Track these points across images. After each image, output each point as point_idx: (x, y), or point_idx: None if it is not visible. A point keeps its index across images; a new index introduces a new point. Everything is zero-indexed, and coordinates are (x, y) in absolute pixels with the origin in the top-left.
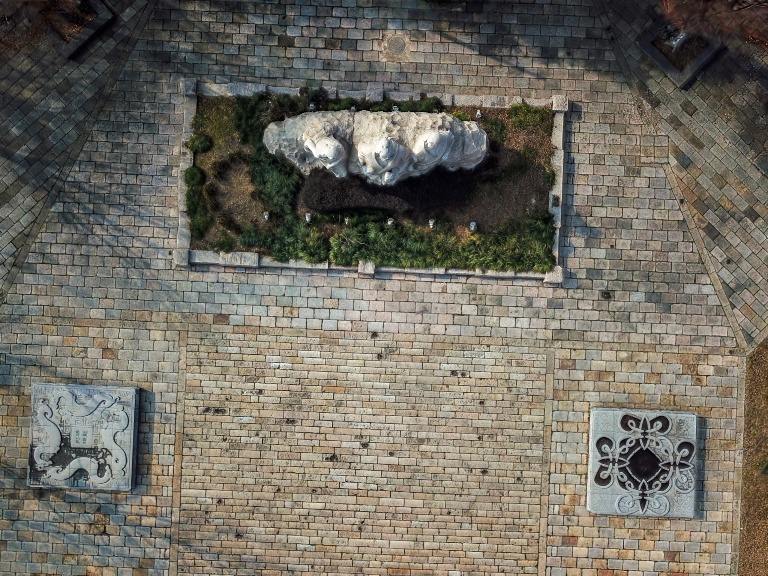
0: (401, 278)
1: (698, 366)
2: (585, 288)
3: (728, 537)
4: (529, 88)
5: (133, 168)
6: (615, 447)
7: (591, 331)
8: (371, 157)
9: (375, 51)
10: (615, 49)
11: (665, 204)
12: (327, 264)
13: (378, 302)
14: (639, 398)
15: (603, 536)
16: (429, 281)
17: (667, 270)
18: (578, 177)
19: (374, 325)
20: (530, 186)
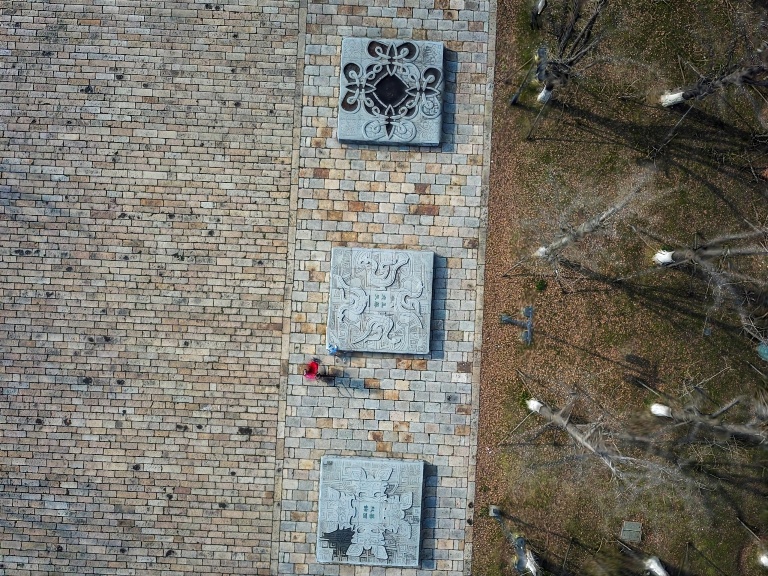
0: None
1: (450, 1)
2: None
3: (478, 170)
4: None
5: None
6: (362, 73)
7: None
8: None
9: None
10: None
11: None
12: None
13: None
14: (391, 32)
15: (355, 168)
16: None
17: None
18: None
19: None
20: None
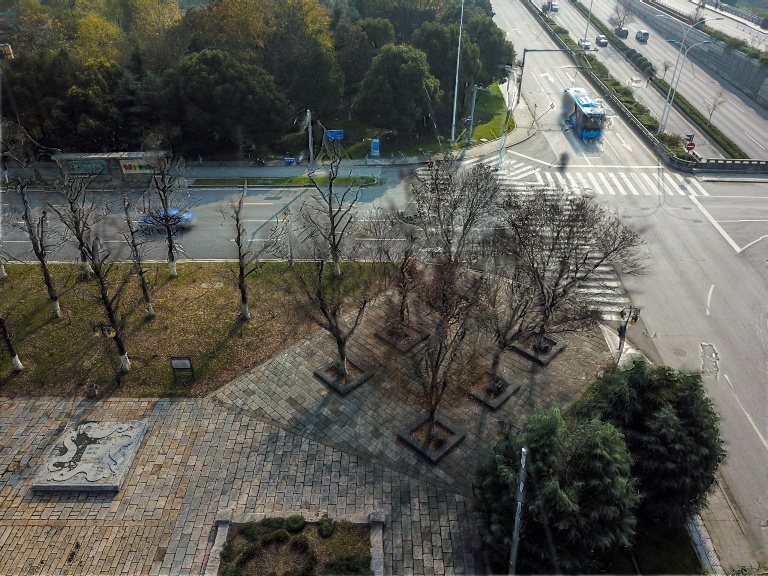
0: None
1: None
2: None
3: None
4: None
5: (310, 480)
6: None
7: None
8: None
9: None
10: None
11: None
12: None
13: None
14: None
15: None
16: None
17: None
18: None
19: None
20: None
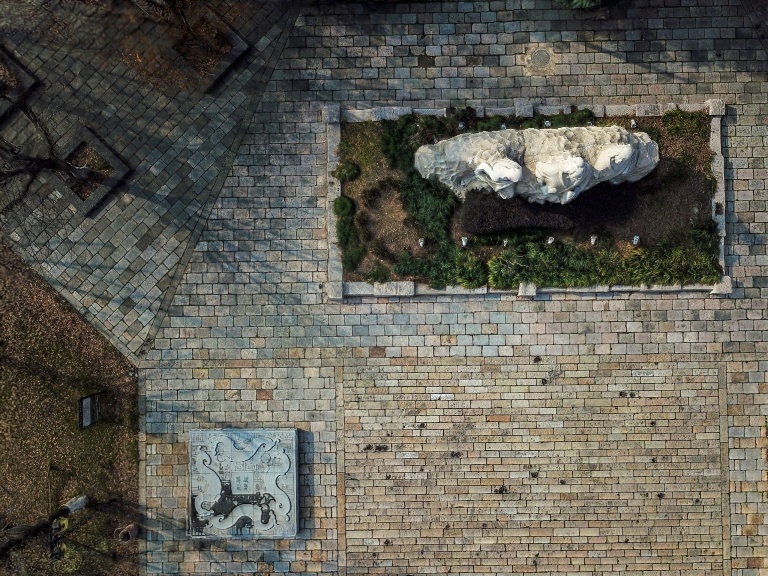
0: (561, 298)
1: None
2: (753, 297)
3: None
4: (680, 94)
5: (277, 201)
6: None
7: (762, 341)
8: (557, 177)
9: (518, 66)
10: (767, 48)
11: None
12: (486, 289)
13: (539, 324)
14: None
15: None
16: (590, 300)
17: None
18: (738, 182)
19: (536, 349)
20: (692, 195)
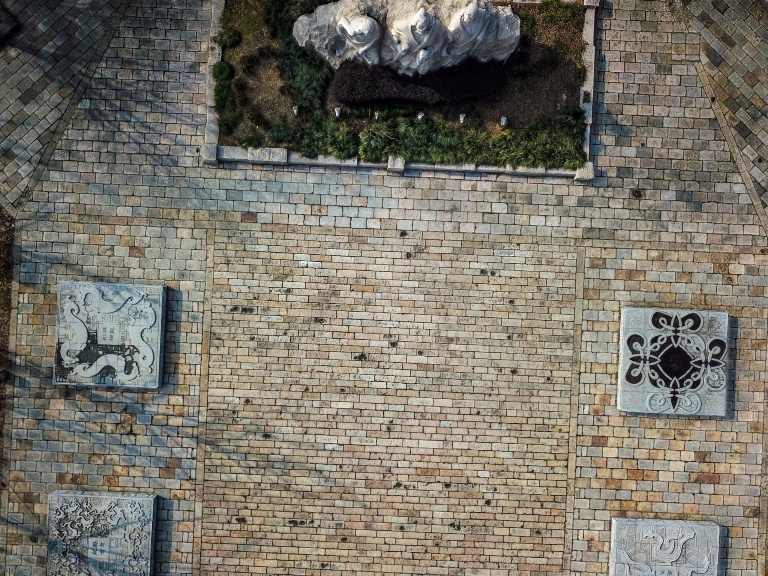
0: (430, 176)
1: (729, 265)
2: (616, 186)
3: (759, 437)
4: None
5: (160, 64)
6: (646, 344)
7: (622, 230)
8: (407, 31)
9: None
10: None
11: (696, 102)
12: (356, 160)
13: (407, 200)
14: (670, 297)
15: (633, 436)
16: (459, 179)
17: (698, 169)
18: (609, 75)
19: (403, 223)
20: (561, 82)
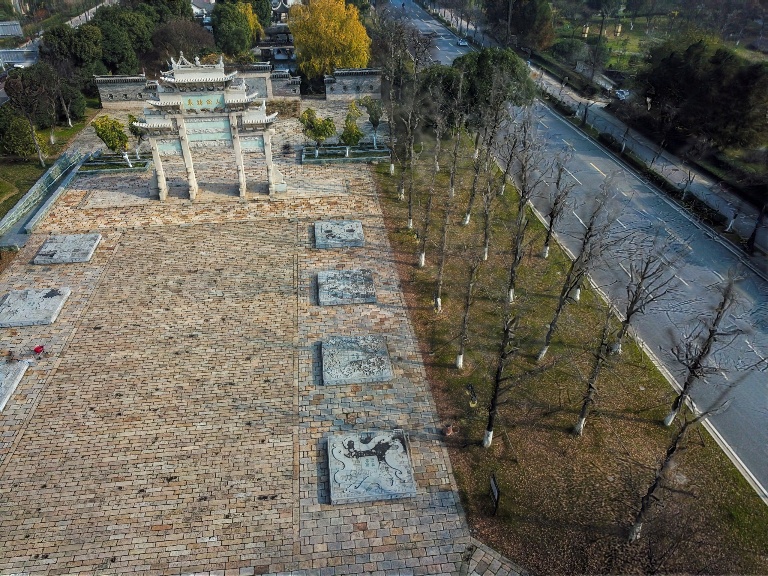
0: None
1: None
2: None
3: None
4: None
5: None
6: None
7: None
8: None
9: None
10: None
11: None
12: None
13: None
14: None
15: None
16: None
17: None
18: None
19: None
20: None
